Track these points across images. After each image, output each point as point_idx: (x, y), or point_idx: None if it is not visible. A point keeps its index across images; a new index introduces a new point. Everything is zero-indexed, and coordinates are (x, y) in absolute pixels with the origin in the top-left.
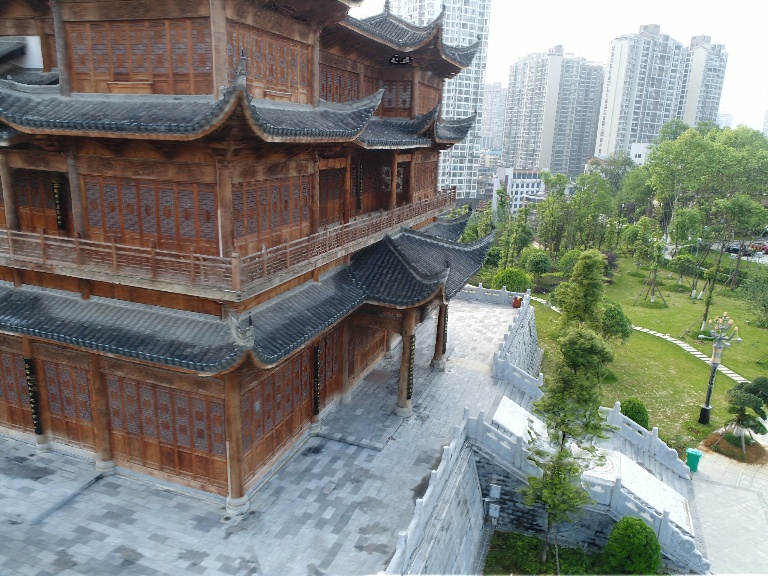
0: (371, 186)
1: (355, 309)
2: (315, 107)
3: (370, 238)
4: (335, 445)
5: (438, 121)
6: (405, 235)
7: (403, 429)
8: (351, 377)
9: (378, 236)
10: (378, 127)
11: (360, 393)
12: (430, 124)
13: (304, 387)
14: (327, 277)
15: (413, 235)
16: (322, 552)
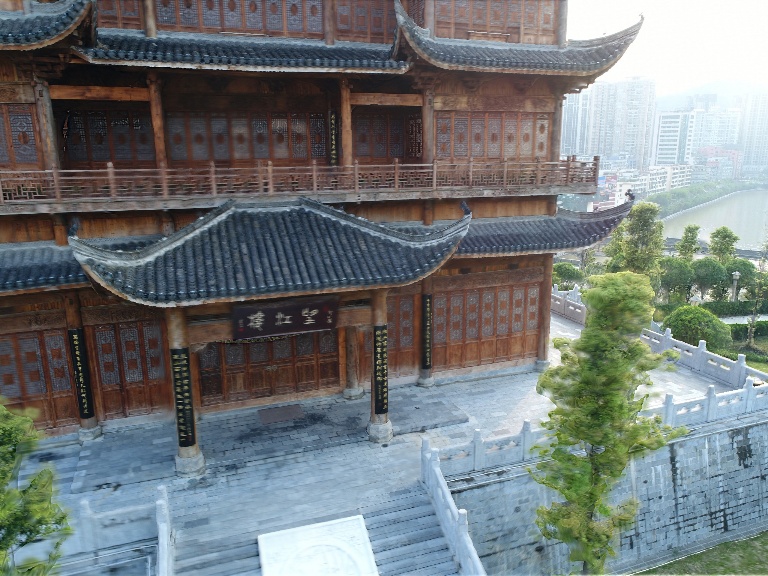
0: (384, 148)
1: (72, 288)
2: (26, 14)
3: (163, 200)
4: (68, 463)
5: (557, 44)
6: (304, 210)
7: (150, 484)
8: (215, 397)
9: (200, 201)
10: (322, 53)
11: (216, 422)
12: (399, 36)
13: (55, 376)
14: (95, 244)
15: (318, 211)
16: None
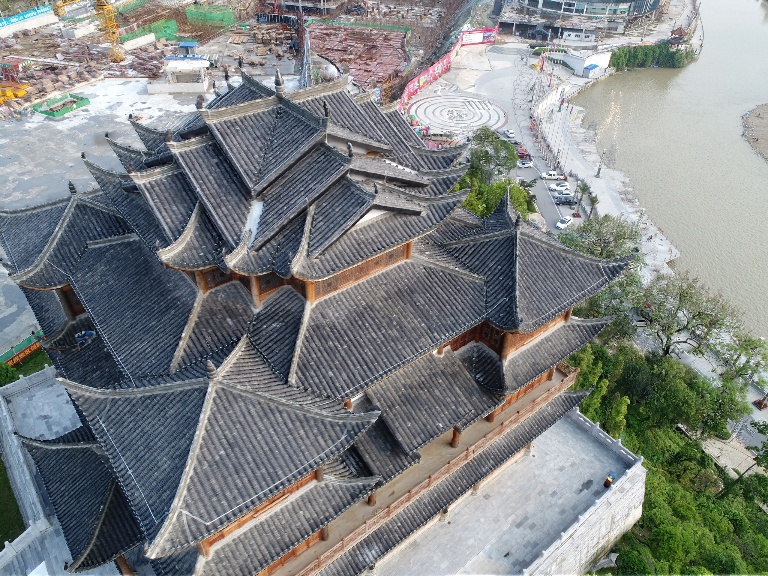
0: None
1: None
2: None
3: None
4: None
5: None
6: None
7: None
8: None
9: None
10: None
11: None
12: None
13: None
14: None
15: None
16: (53, 423)
